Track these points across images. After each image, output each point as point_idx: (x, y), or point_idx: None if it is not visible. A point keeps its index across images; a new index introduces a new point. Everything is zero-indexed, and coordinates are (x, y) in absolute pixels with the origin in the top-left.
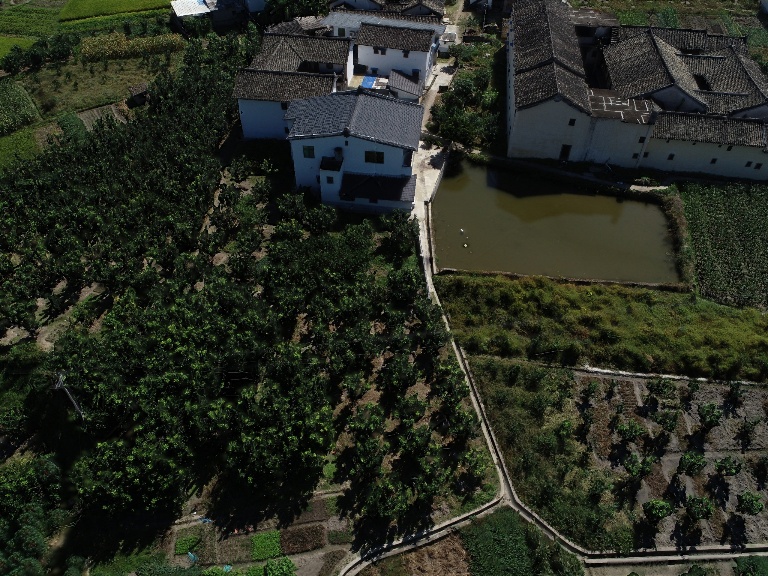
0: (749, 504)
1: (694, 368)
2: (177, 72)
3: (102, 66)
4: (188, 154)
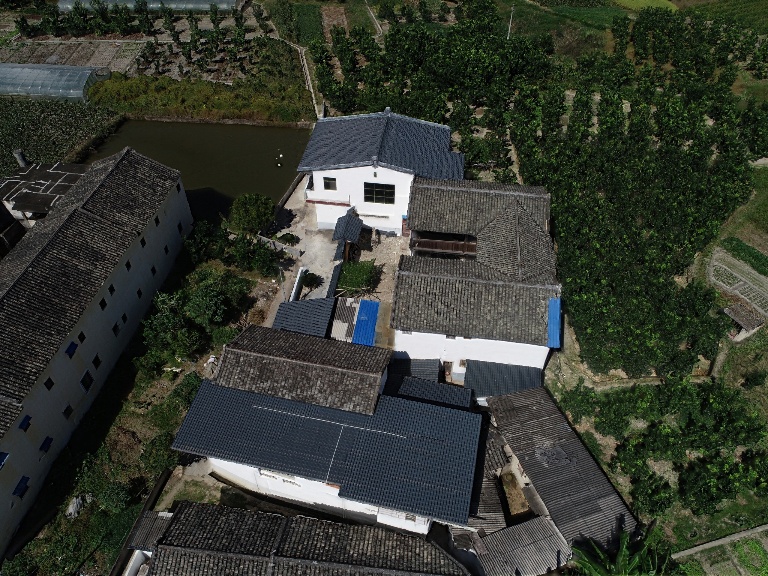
0: None
1: None
2: None
3: None
4: None
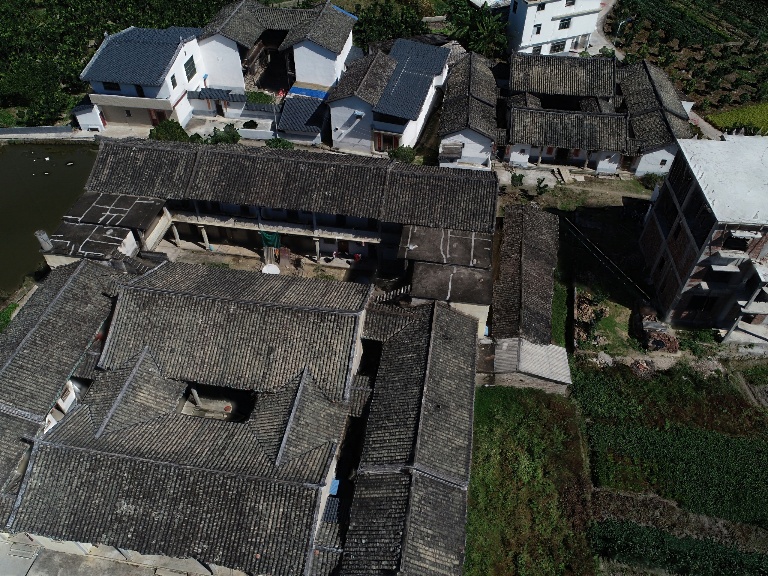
0: None
1: None
2: None
3: None
4: None
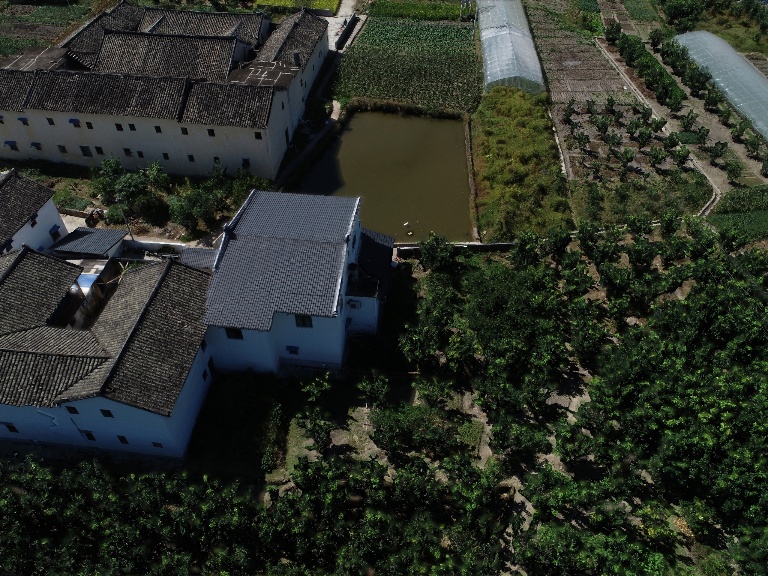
0: (663, 121)
1: (551, 127)
2: None
3: None
4: None
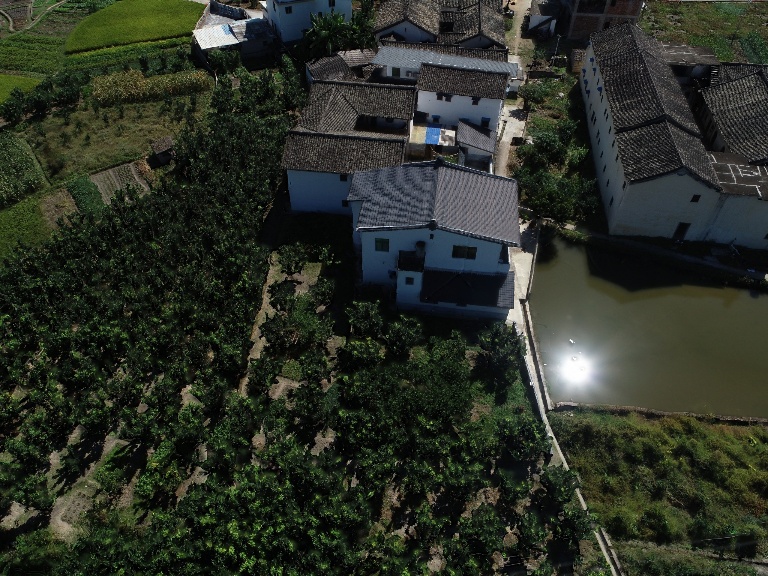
0: None
1: None
2: (205, 120)
3: (117, 112)
4: (229, 241)
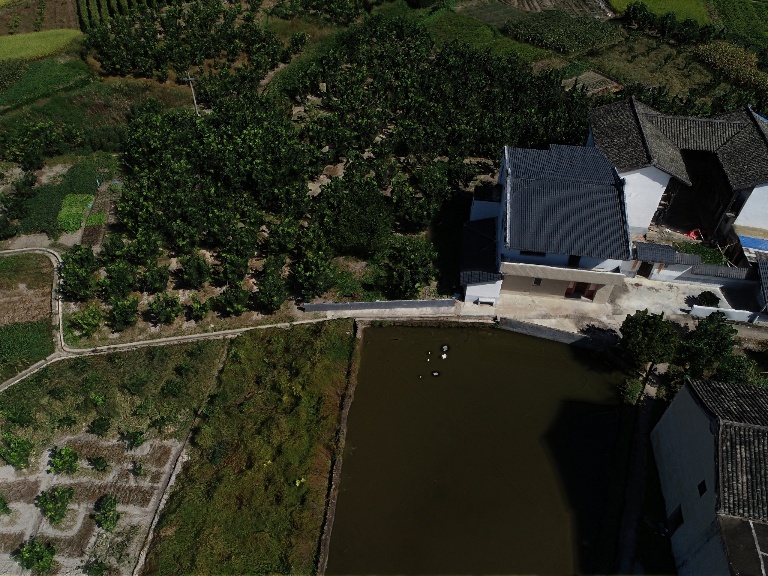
0: None
1: None
2: (705, 106)
3: None
4: None
